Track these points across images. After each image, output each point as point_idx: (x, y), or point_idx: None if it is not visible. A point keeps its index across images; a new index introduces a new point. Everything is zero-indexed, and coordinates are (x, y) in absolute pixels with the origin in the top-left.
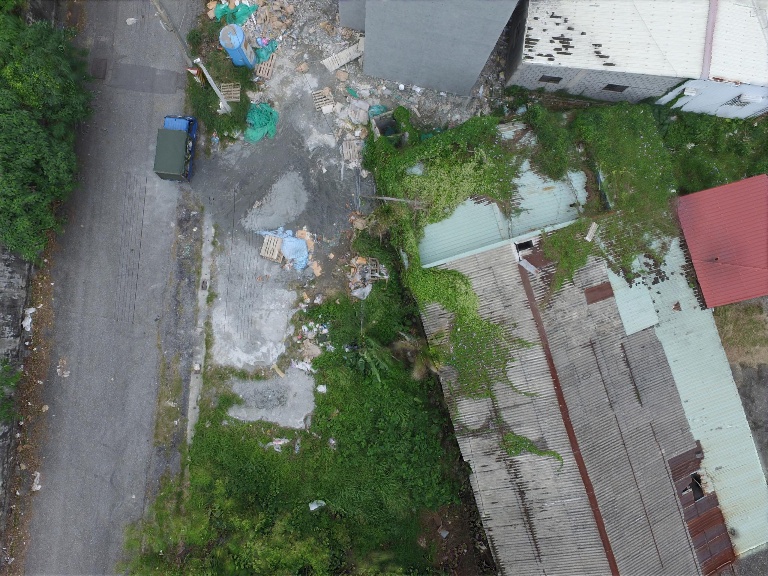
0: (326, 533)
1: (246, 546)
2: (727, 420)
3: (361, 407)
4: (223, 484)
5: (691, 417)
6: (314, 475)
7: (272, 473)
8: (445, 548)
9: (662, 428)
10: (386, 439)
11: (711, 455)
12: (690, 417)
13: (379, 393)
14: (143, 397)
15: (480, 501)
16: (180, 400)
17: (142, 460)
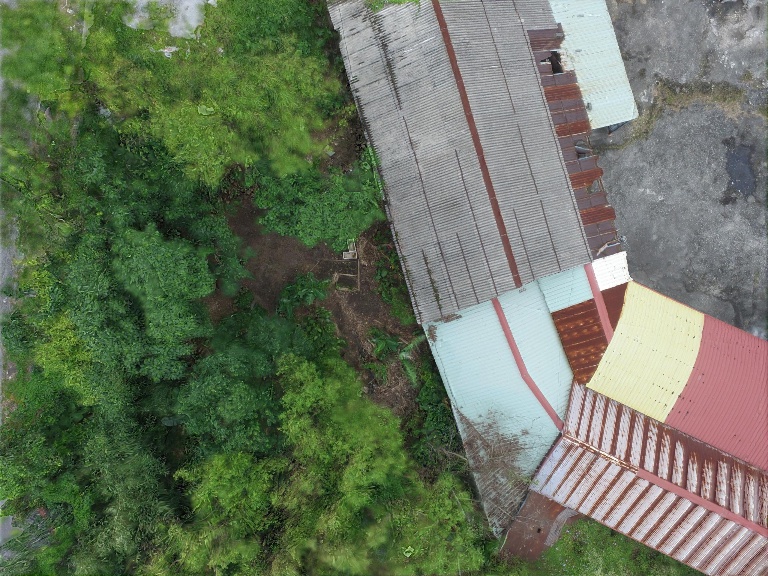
0: (211, 127)
1: (131, 126)
2: (589, 9)
3: (247, 12)
4: (112, 75)
5: (554, 3)
6: (201, 73)
7: (161, 73)
8: (331, 167)
9: (523, 3)
10: (267, 30)
11: (572, 38)
12: (553, 2)
13: (265, 1)
14: (40, 2)
15: (348, 65)
16: (76, 8)
17: (37, 59)
